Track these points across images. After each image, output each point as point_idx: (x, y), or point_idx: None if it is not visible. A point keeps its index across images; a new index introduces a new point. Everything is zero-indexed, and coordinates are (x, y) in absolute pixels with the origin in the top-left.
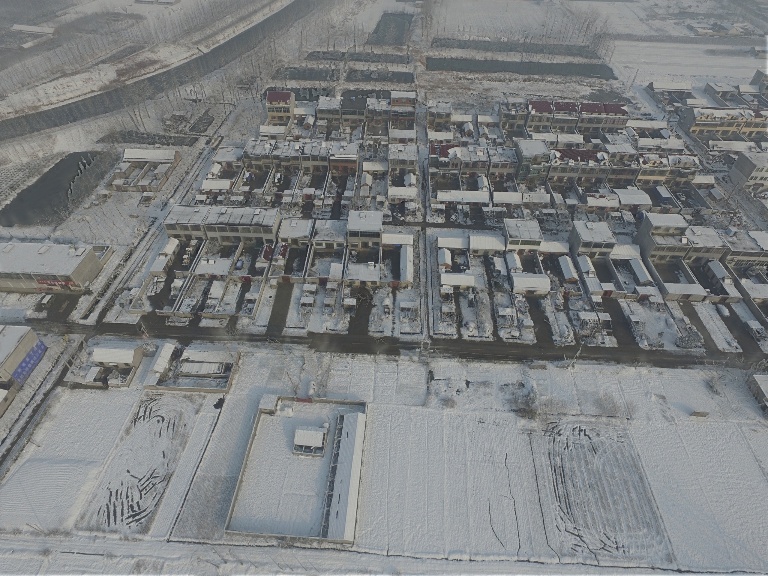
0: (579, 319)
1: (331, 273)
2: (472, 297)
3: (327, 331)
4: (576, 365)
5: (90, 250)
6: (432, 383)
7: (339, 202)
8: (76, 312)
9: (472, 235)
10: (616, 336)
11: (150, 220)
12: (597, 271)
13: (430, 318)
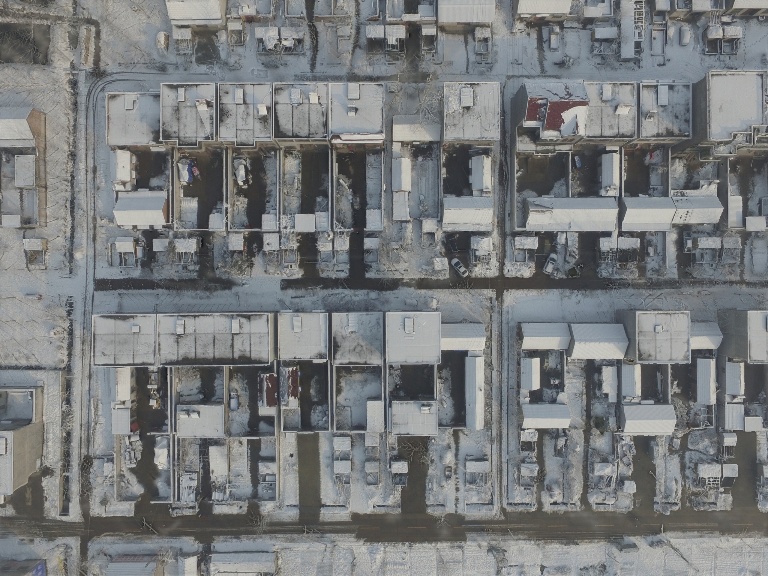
0: (696, 474)
1: (369, 423)
2: (562, 444)
3: (375, 511)
4: (673, 540)
5: (13, 439)
6: (502, 572)
7: (359, 234)
8: (49, 505)
9: (579, 339)
10: (734, 493)
11: (63, 301)
12: (745, 375)
13: (504, 478)
